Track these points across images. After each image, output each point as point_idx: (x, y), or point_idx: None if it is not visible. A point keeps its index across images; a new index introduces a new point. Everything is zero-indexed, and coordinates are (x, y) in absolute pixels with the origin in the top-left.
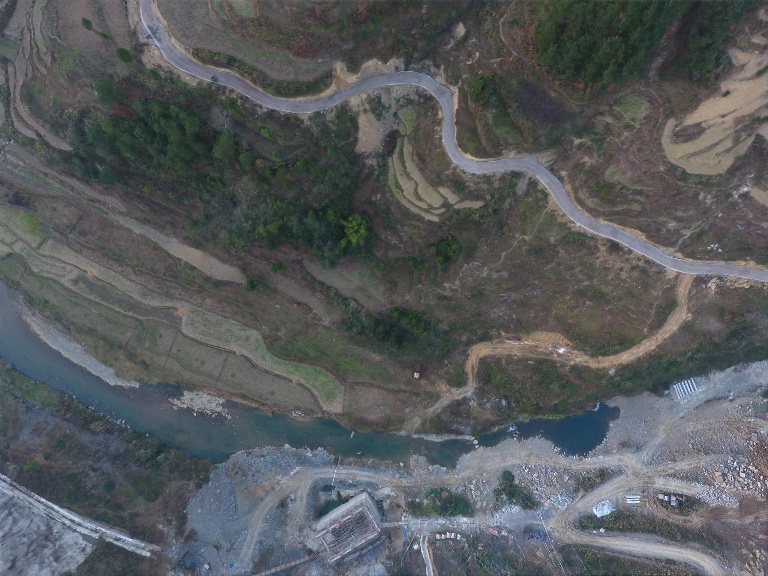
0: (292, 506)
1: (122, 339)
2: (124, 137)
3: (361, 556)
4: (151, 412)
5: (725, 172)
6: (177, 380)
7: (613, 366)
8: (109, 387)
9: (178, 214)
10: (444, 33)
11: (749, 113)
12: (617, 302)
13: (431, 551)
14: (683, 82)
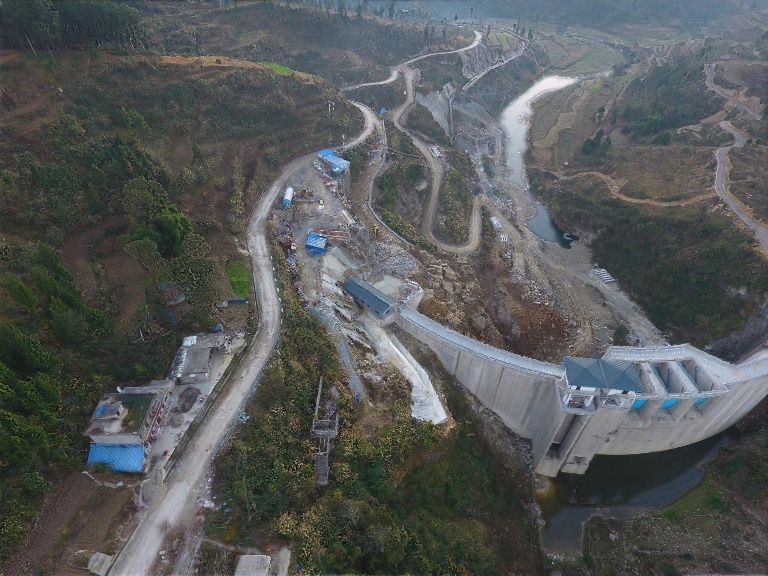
0: None
1: (552, 103)
2: None
3: None
4: (517, 109)
5: None
6: None
7: None
8: (526, 102)
9: None
10: None
11: None
12: None
13: None
14: None
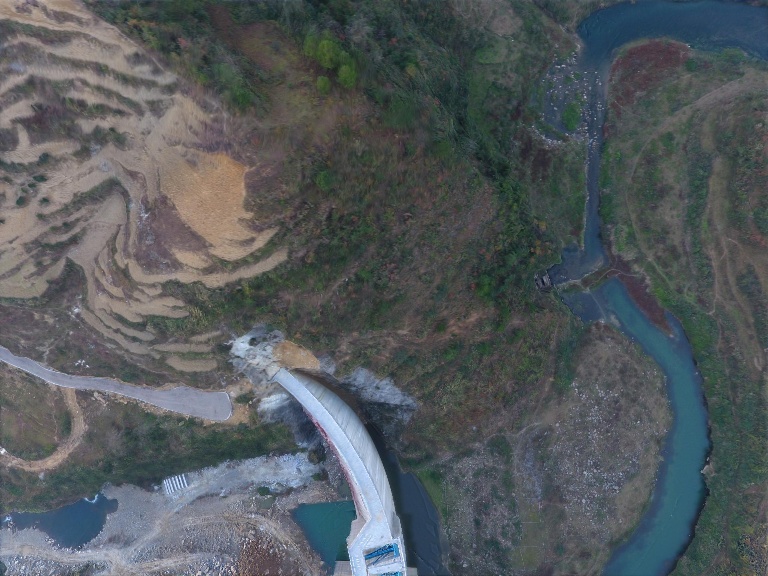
0: None
1: None
2: None
3: None
4: None
5: (40, 295)
6: None
7: (42, 471)
8: None
9: None
10: None
11: (29, 241)
12: (23, 410)
13: None
14: None
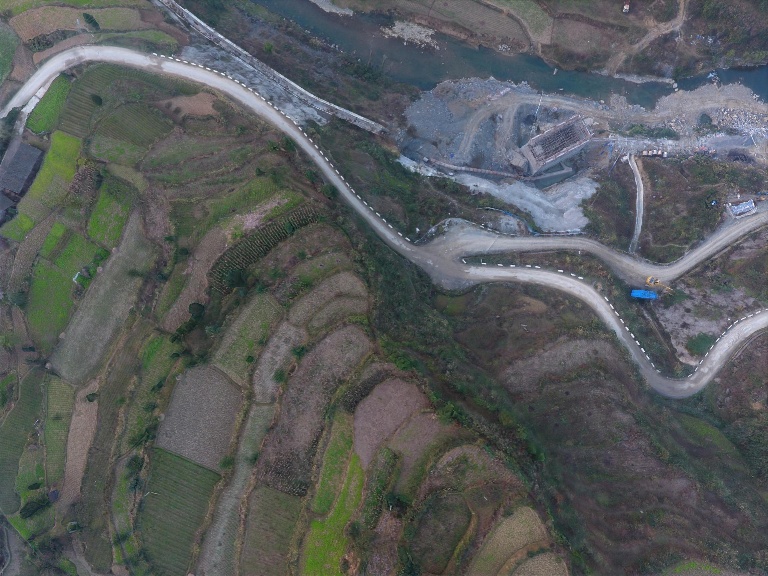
0: (500, 125)
1: None
2: None
3: (561, 182)
4: (363, 39)
5: None
6: (391, 8)
7: None
8: (324, 14)
9: None
10: None
11: None
12: None
13: (640, 162)
14: None
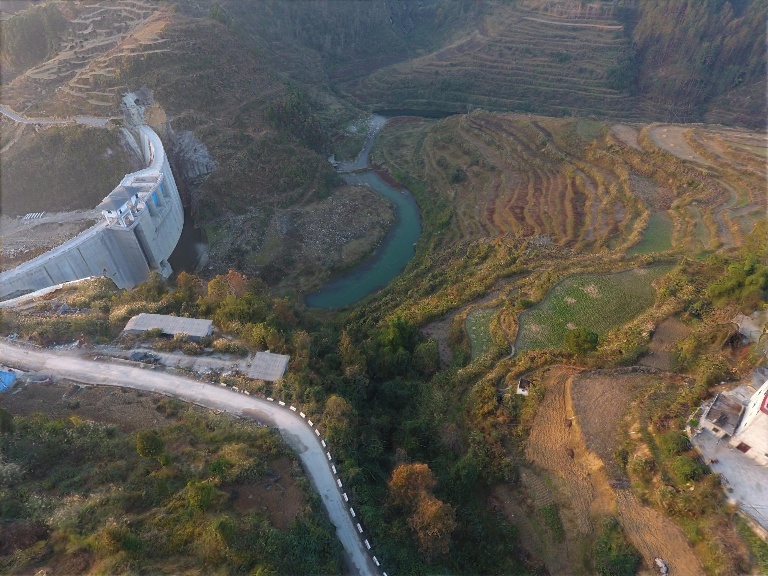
0: None
1: None
2: None
3: None
4: None
5: None
6: None
7: None
8: None
9: None
10: None
11: (63, 59)
12: None
13: None
14: None
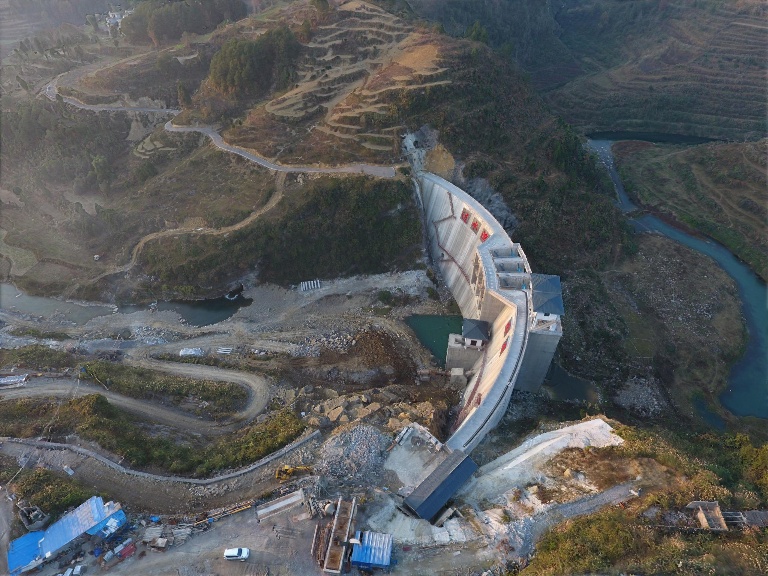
0: None
1: None
2: (1, 118)
3: None
4: None
5: None
6: None
7: (228, 232)
8: None
9: (12, 175)
10: (189, 94)
11: (308, 92)
12: (239, 192)
13: None
14: (284, 90)
